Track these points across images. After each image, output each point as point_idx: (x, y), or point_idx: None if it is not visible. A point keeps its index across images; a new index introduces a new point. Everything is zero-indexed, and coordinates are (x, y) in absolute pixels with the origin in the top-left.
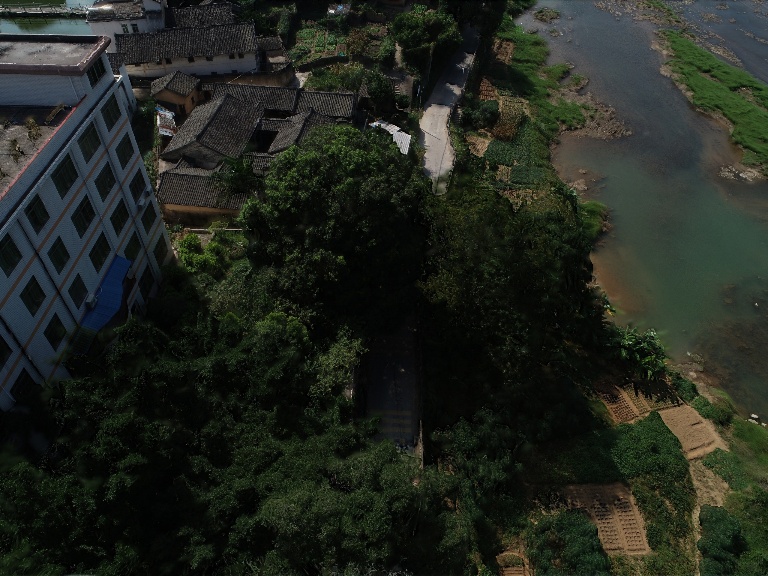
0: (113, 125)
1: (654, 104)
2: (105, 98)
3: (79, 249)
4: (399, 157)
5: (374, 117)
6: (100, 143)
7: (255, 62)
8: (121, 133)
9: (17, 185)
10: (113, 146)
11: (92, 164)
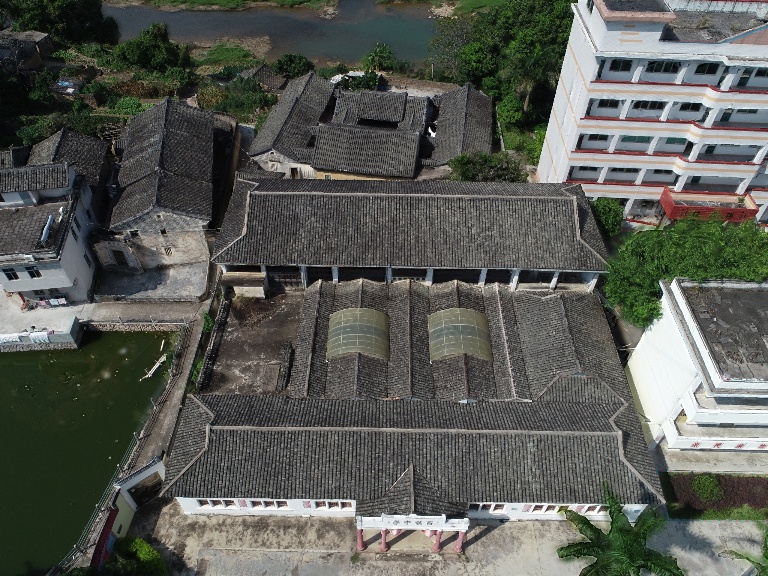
0: None
1: (224, 23)
2: None
3: None
4: None
5: None
6: None
7: None
8: None
9: (746, 2)
10: None
11: None
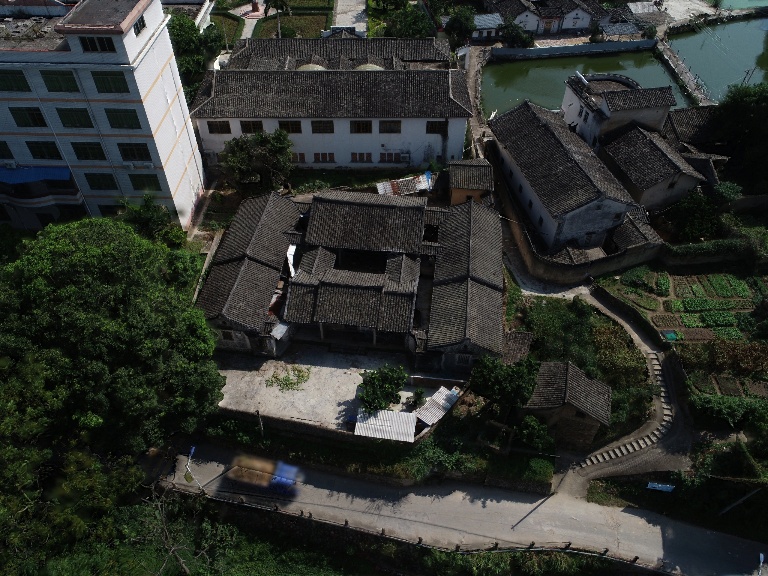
0: (111, 92)
1: None
2: (90, 65)
3: (13, 130)
4: (82, 329)
5: (466, 389)
6: (79, 91)
7: (556, 229)
8: (123, 104)
9: None
10: (103, 105)
11: (58, 96)
